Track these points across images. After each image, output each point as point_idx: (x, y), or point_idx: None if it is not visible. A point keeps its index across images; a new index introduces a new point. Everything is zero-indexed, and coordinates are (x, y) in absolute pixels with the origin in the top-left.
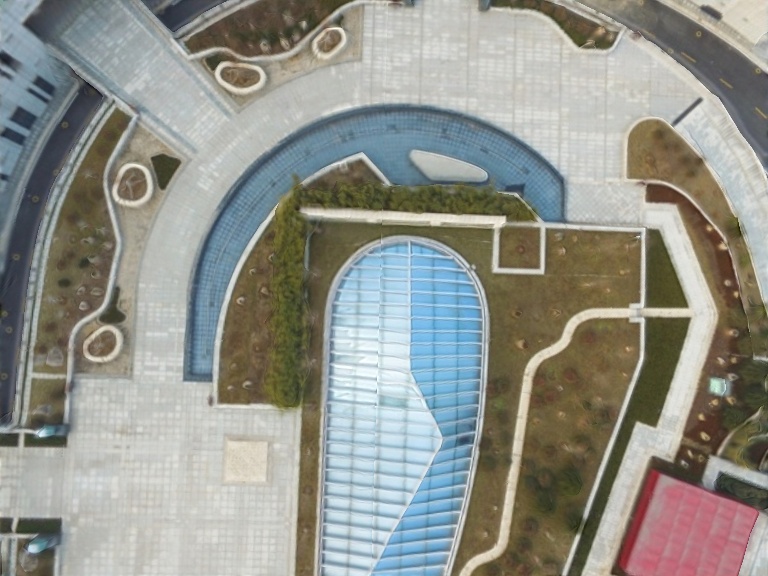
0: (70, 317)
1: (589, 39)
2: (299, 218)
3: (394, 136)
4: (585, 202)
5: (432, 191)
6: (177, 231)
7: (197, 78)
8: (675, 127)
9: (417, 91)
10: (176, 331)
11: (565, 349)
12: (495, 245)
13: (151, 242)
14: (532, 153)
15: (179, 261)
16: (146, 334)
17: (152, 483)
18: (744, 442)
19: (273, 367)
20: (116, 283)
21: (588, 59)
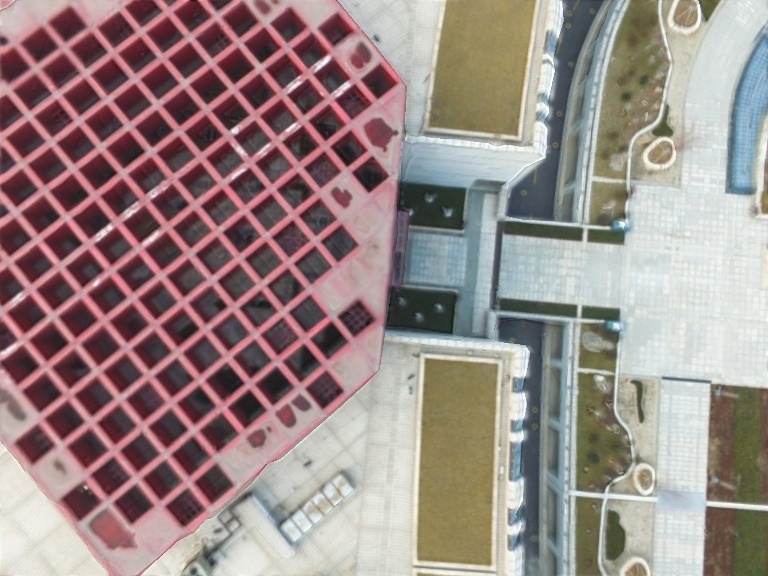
0: (631, 127)
1: None
2: None
3: None
4: None
5: None
6: (719, 58)
7: None
8: None
9: None
10: (719, 148)
11: None
12: None
13: (697, 66)
14: None
15: (721, 85)
16: (692, 149)
17: (699, 283)
18: None
19: None
20: (666, 101)
21: None
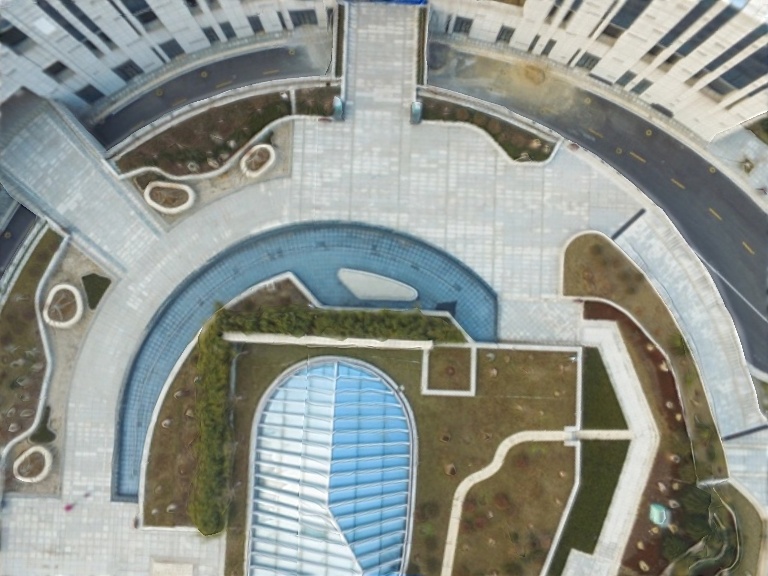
0: (1, 437)
1: (524, 151)
2: (220, 346)
3: (323, 253)
4: (520, 319)
5: (354, 318)
6: (106, 351)
7: (128, 197)
8: (616, 240)
9: (347, 207)
10: (104, 451)
11: (496, 473)
12: (424, 366)
13: (81, 362)
14: (464, 269)
15: (108, 381)
16: (75, 454)
17: None
18: (684, 574)
19: (194, 495)
20: (47, 403)
21: (524, 171)
